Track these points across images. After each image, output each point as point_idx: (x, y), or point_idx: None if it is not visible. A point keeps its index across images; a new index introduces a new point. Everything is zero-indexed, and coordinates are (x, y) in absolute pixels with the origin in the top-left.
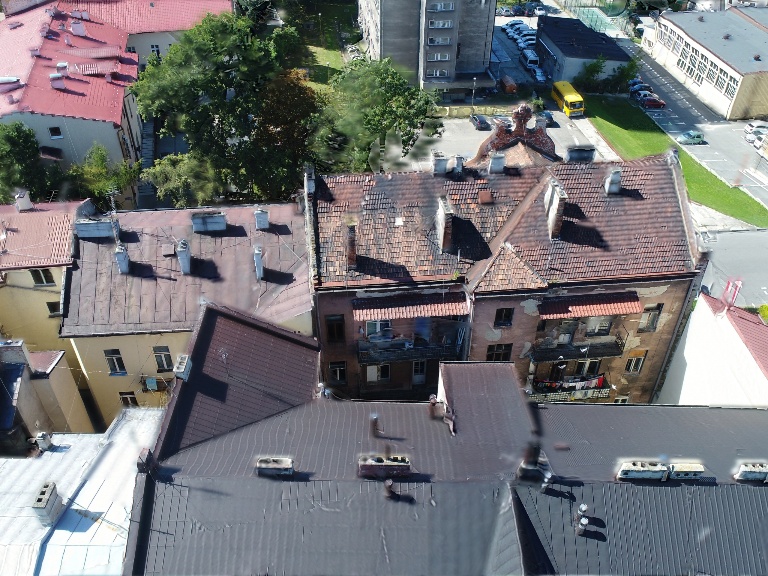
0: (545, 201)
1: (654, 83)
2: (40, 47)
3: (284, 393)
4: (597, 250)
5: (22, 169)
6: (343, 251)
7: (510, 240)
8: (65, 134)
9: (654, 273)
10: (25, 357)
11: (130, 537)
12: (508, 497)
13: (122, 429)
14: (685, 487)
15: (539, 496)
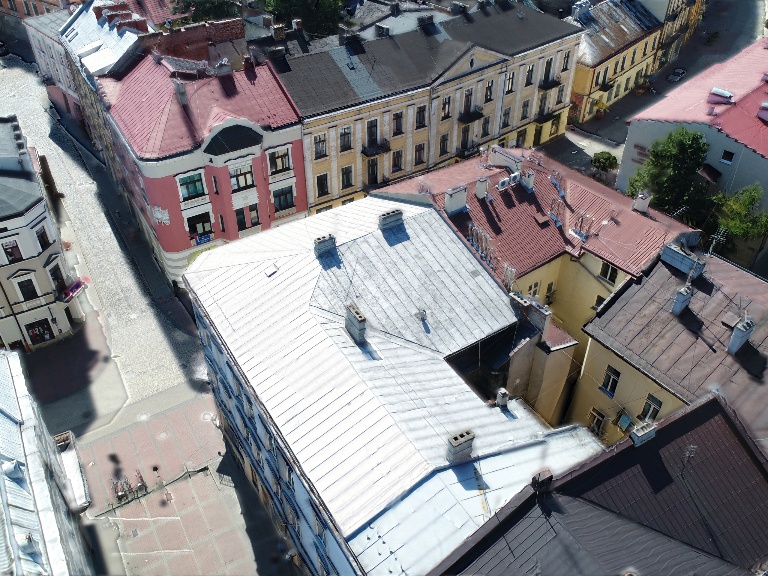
0: None
1: None
2: None
3: (724, 537)
4: None
5: (673, 174)
6: None
7: None
8: (735, 162)
9: None
10: (544, 326)
11: (485, 526)
12: None
13: (562, 438)
14: None
15: None
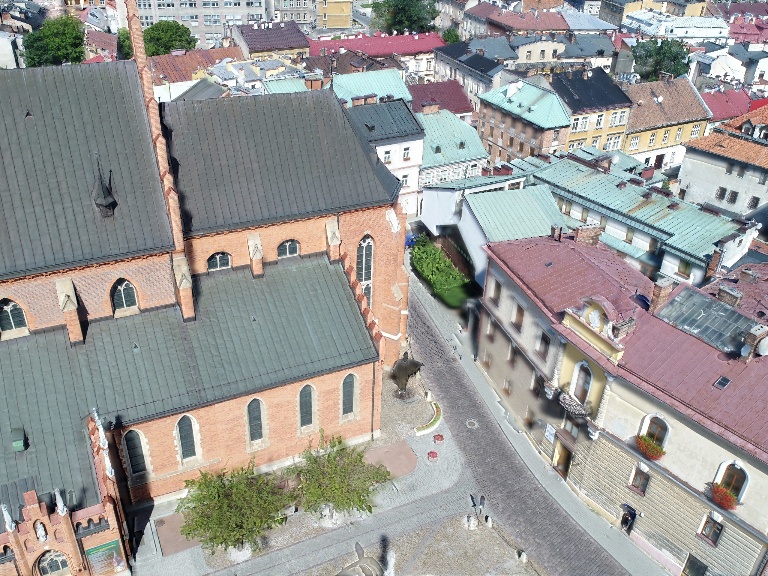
0: None
1: None
2: None
3: None
4: None
5: None
6: None
7: None
8: None
9: None
10: None
11: None
12: None
13: None
14: None
15: None
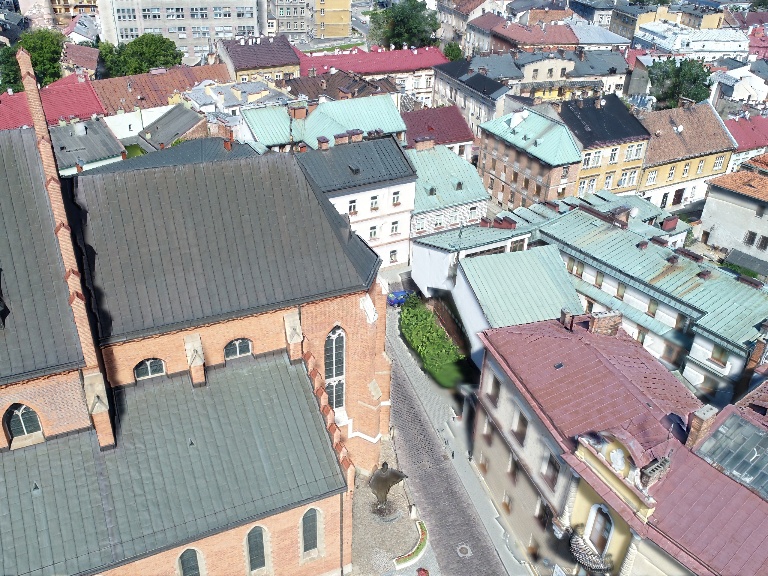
0: None
1: None
2: (368, 53)
3: None
4: None
5: None
6: None
7: None
8: None
9: None
10: None
11: None
12: None
13: None
14: None
15: None
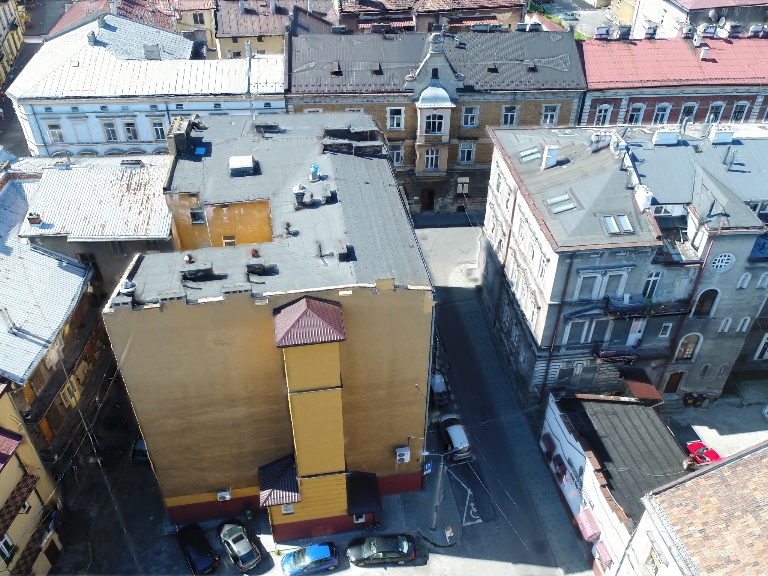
0: None
1: None
2: None
3: None
4: None
5: None
6: None
7: None
8: None
9: (503, 4)
10: (206, 38)
11: (286, 50)
12: (429, 36)
13: None
14: (497, 33)
15: None
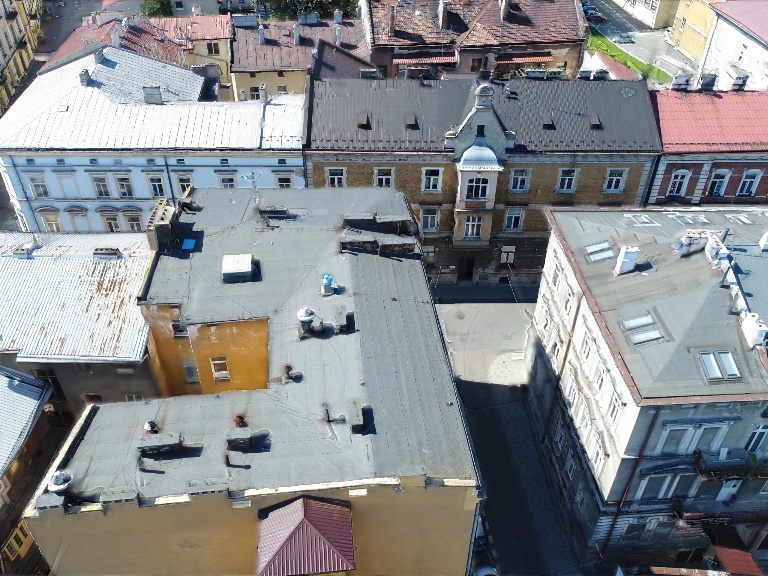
0: (499, 1)
1: (600, 7)
2: None
3: None
4: (528, 27)
5: None
6: (387, 27)
7: (480, 22)
8: (186, 7)
9: (560, 39)
10: (219, 73)
11: (306, 98)
12: None
13: (279, 96)
14: (555, 81)
15: (489, 83)
